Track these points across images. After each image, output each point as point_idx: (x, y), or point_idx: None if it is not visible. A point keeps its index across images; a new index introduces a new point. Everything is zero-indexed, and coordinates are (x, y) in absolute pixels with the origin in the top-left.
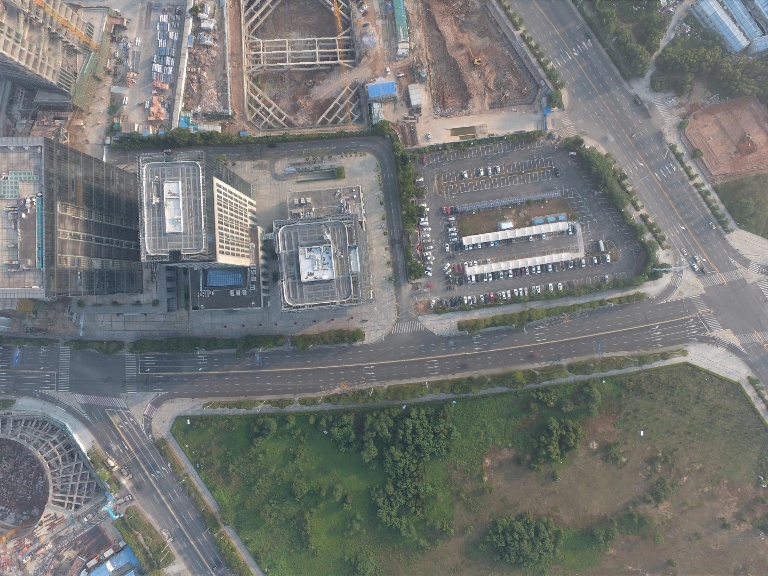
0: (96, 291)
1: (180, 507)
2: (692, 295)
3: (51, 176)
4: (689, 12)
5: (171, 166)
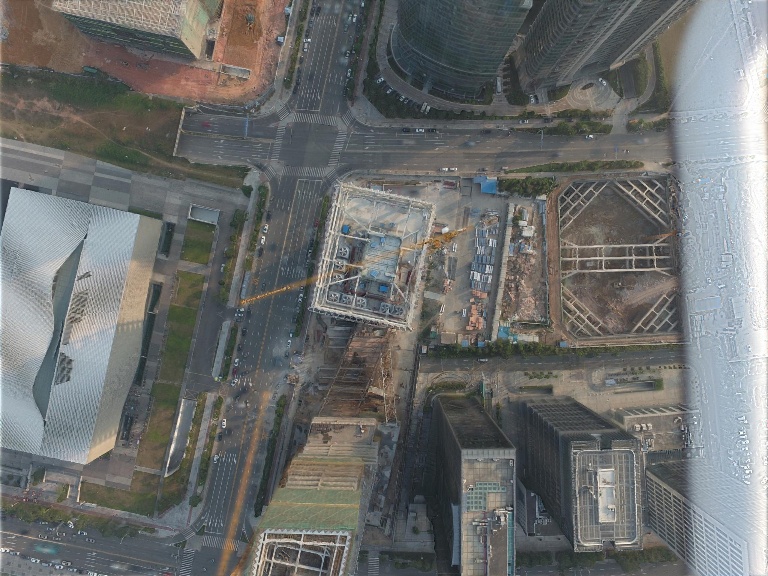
0: None
1: None
2: None
3: None
4: None
5: (604, 453)
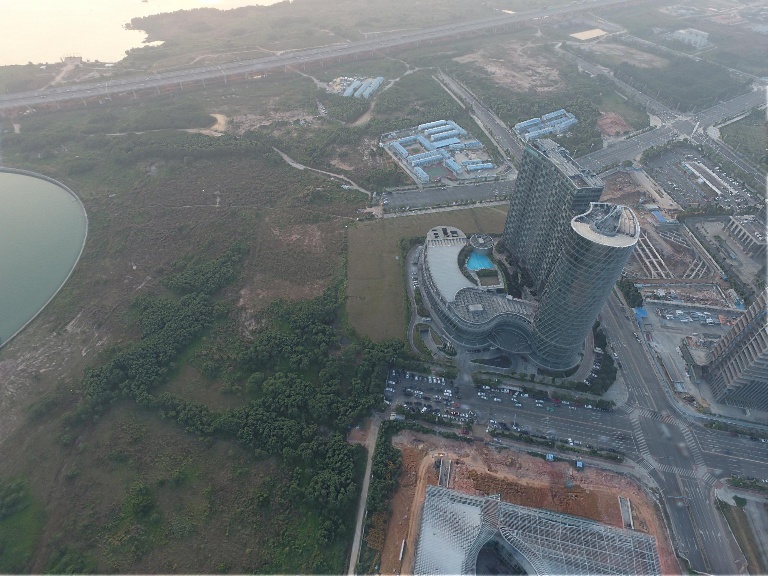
0: None
1: None
2: (689, 137)
3: None
4: (561, 133)
5: None
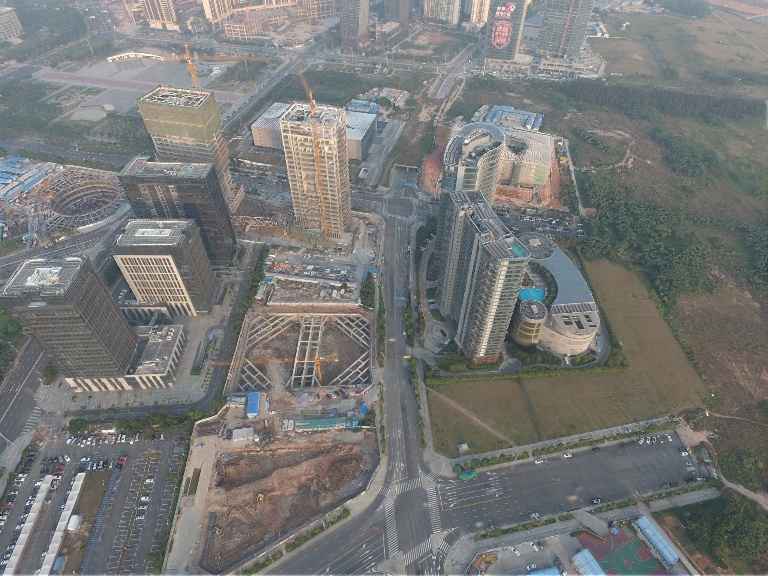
0: (136, 211)
1: (6, 269)
2: None
3: (186, 182)
4: None
5: None
